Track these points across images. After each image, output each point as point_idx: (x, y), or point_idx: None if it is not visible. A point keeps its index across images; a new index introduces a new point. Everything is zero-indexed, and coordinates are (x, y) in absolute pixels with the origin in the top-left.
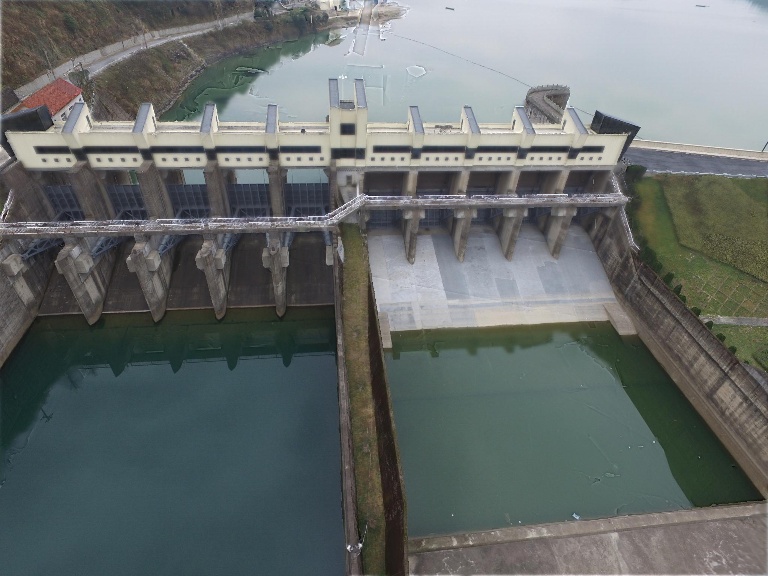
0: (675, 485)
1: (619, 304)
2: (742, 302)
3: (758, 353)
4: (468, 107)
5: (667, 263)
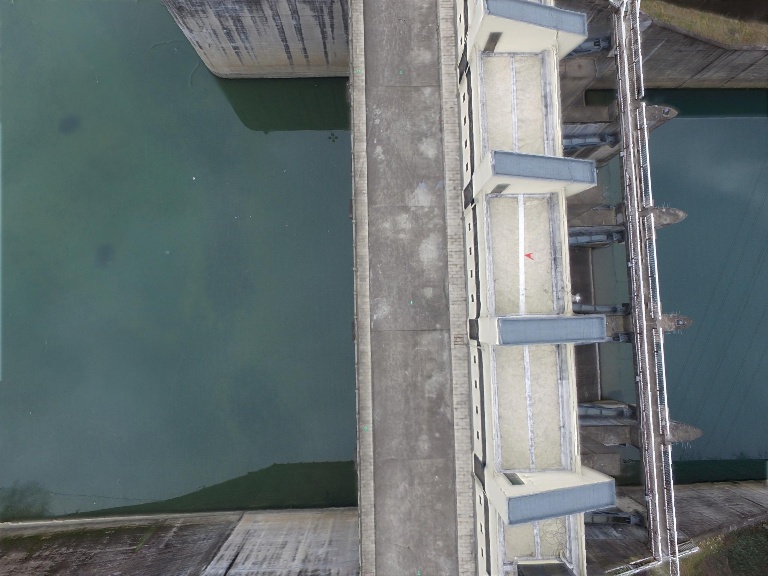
0: None
1: None
2: None
3: None
4: None
5: None
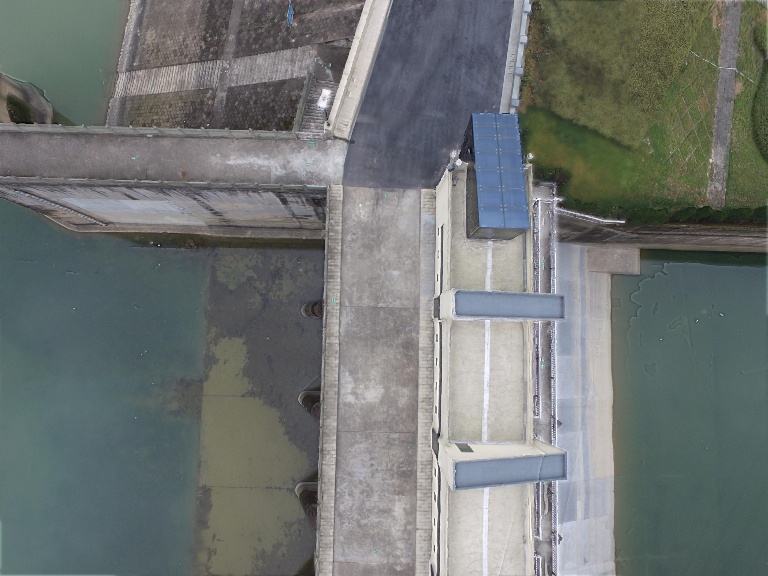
0: (723, 269)
1: (592, 247)
2: (700, 112)
3: None
4: None
5: (643, 187)
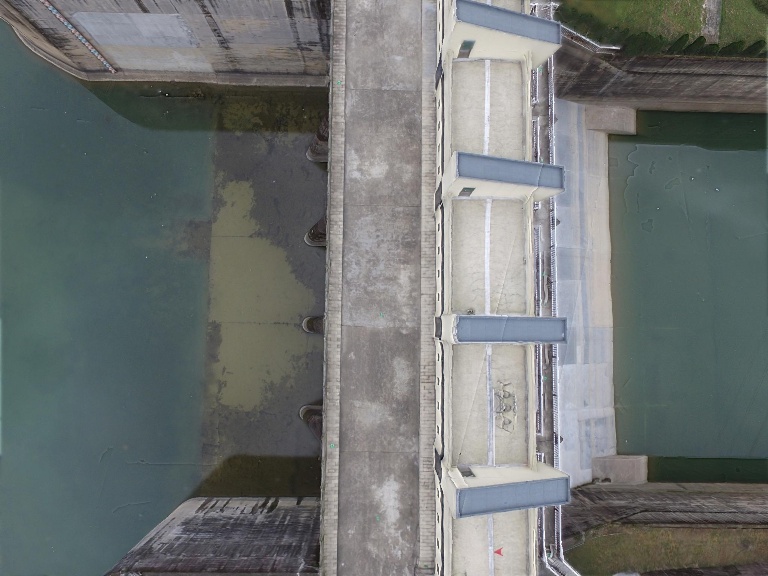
0: (719, 154)
1: (590, 106)
2: None
3: (764, 4)
4: (458, 327)
5: (638, 19)
